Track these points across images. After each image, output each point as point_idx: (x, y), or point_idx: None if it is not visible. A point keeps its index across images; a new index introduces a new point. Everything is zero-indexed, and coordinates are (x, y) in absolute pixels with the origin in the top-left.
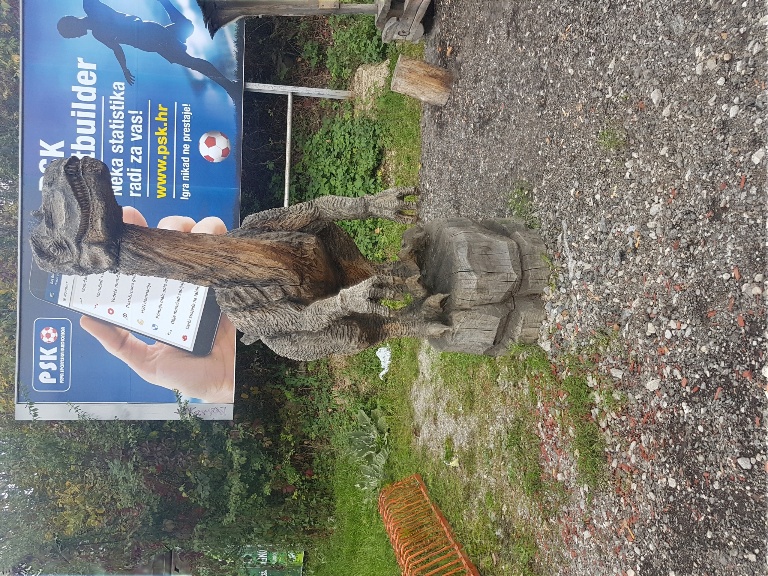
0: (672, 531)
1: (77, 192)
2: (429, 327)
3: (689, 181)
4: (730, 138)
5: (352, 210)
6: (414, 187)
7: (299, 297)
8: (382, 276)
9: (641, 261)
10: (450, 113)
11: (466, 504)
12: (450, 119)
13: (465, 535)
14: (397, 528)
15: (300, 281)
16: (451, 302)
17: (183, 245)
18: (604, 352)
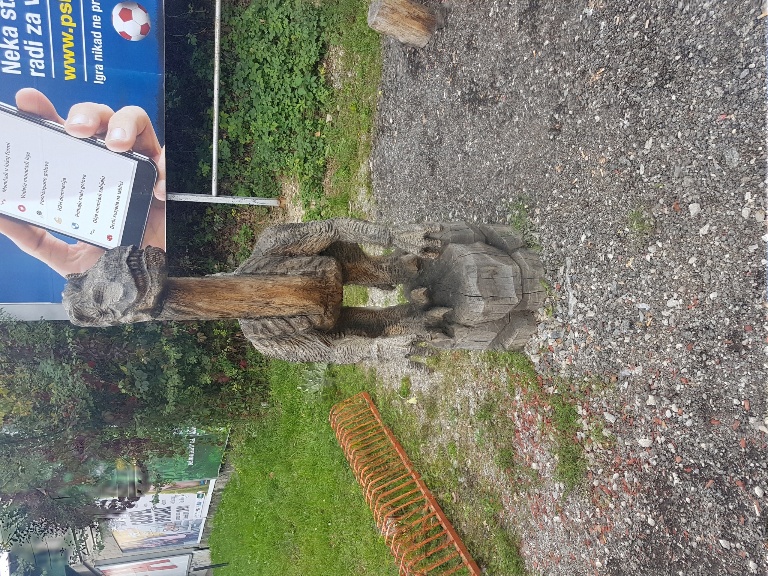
0: (645, 555)
1: (139, 283)
2: None
3: (714, 302)
4: (764, 292)
5: (374, 238)
6: (440, 225)
7: (323, 324)
8: (421, 334)
9: (650, 339)
10: (428, 60)
11: (424, 441)
12: (428, 66)
13: (421, 465)
14: (354, 450)
15: (325, 310)
16: (454, 316)
17: (222, 296)
18: (596, 390)
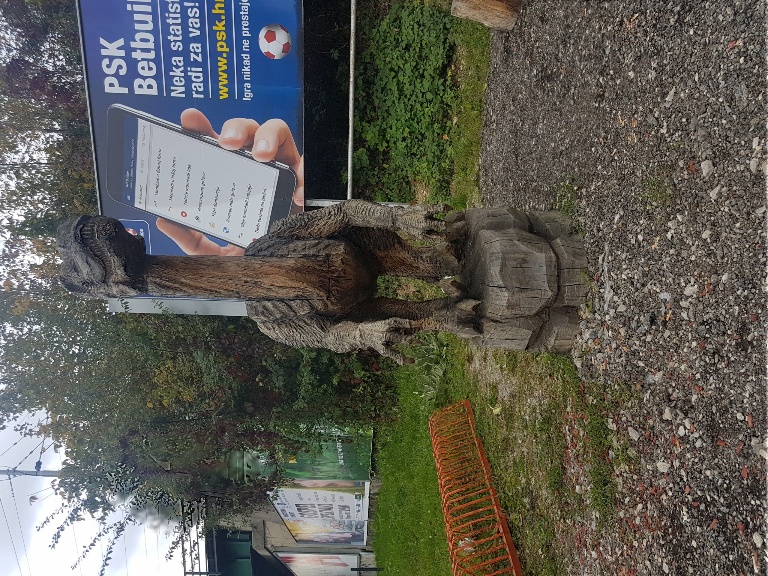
0: None
1: (95, 252)
2: (459, 332)
3: (725, 286)
4: None
5: (380, 221)
6: (443, 205)
7: (326, 310)
8: (399, 320)
9: (670, 337)
10: (516, 42)
11: (503, 455)
12: (516, 49)
13: (501, 482)
14: (441, 459)
15: (327, 295)
16: (483, 309)
17: (208, 273)
18: None
